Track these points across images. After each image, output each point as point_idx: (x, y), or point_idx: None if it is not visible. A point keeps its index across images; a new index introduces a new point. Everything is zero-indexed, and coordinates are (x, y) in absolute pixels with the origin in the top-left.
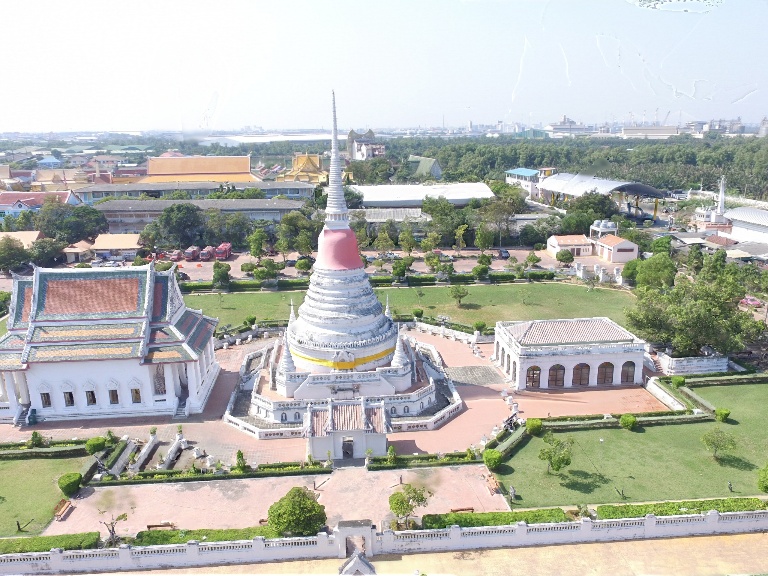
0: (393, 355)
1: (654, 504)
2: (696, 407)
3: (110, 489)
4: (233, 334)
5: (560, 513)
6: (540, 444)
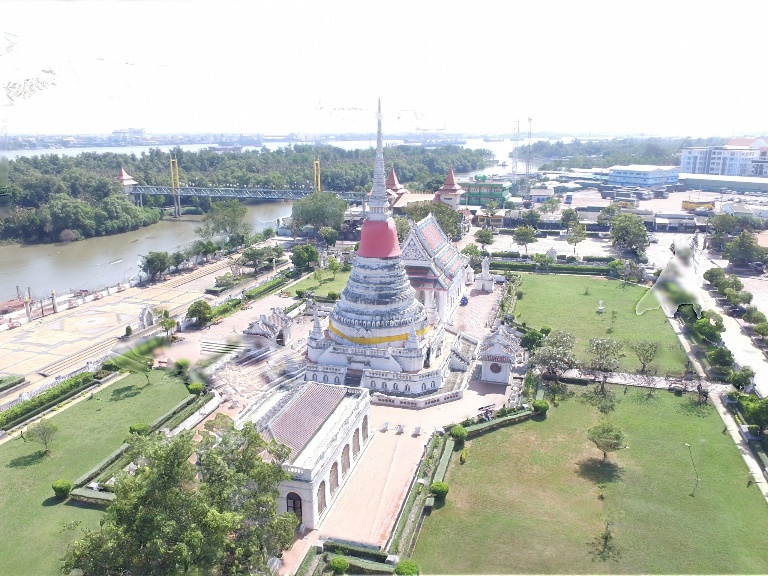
0: (343, 341)
1: (64, 387)
2: (100, 491)
3: (294, 301)
4: (515, 327)
5: (109, 363)
6: (181, 394)
